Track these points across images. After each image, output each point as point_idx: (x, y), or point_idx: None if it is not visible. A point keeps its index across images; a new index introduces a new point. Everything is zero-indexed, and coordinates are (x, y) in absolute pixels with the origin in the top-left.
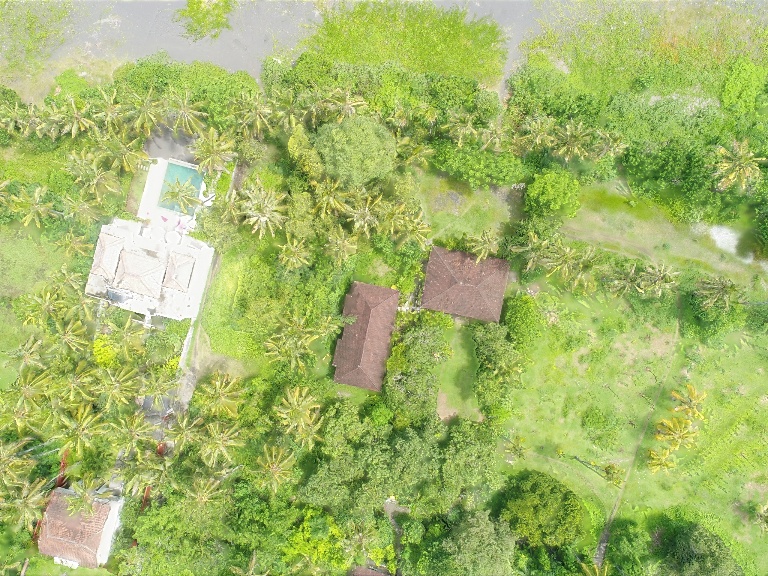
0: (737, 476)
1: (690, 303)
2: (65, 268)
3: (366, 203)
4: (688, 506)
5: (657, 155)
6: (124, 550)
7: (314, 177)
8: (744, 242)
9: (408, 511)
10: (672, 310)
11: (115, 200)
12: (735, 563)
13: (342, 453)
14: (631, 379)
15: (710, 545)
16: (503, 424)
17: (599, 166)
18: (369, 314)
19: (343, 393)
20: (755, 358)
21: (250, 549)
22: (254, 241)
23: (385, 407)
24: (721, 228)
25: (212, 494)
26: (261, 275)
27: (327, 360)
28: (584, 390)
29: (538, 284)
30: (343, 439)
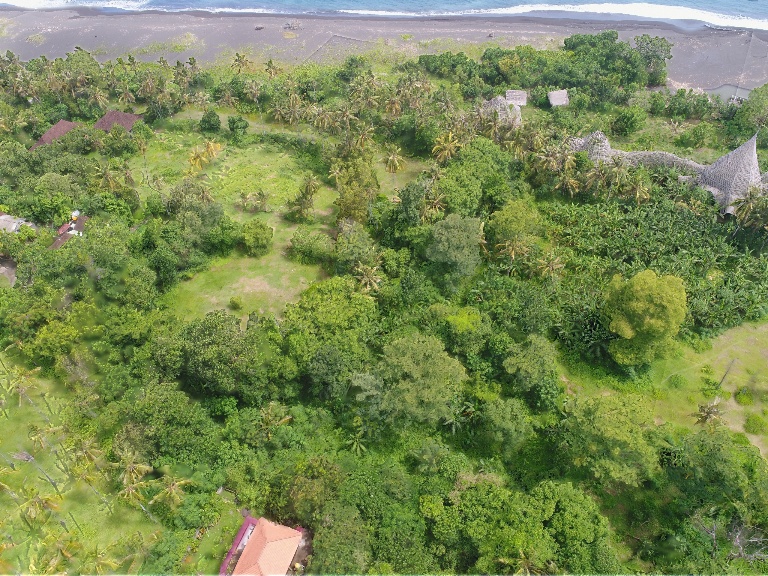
0: None
1: None
2: None
3: None
4: None
5: None
6: None
7: None
8: None
9: None
10: (224, 135)
11: None
12: None
13: None
14: None
15: None
16: None
17: None
18: (59, 121)
19: None
20: (264, 152)
21: None
22: None
23: None
24: None
25: None
26: None
27: (29, 142)
28: None
29: (160, 131)
30: (13, 155)
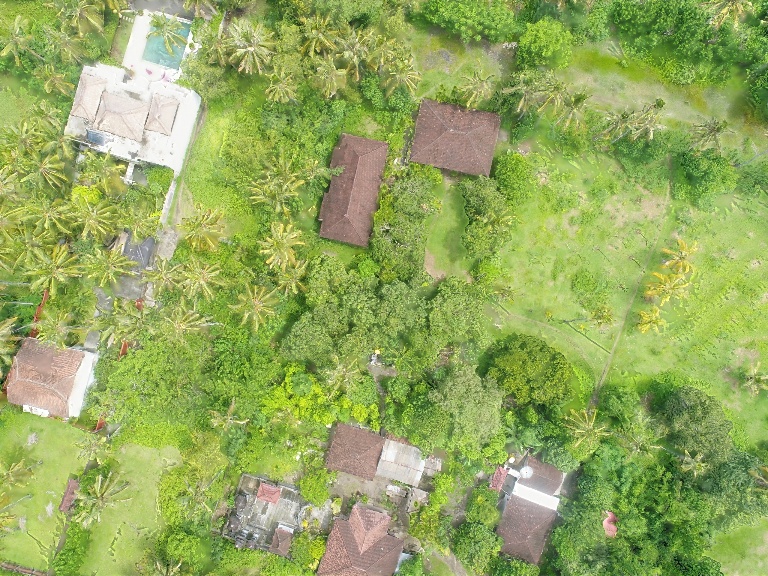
0: (727, 342)
1: (681, 163)
2: (44, 105)
3: (356, 38)
4: (678, 372)
5: (649, 7)
6: (97, 393)
7: (303, 13)
8: (735, 105)
9: (393, 375)
10: (663, 171)
11: (98, 42)
12: (725, 419)
13: (326, 302)
14: (621, 242)
15: (700, 396)
16: (492, 286)
17: (591, 24)
18: (357, 162)
19: (329, 253)
20: (746, 221)
21: (229, 400)
22: (241, 96)
23: (372, 260)
24: (712, 91)
25: (191, 324)
26: (247, 128)
27: (313, 212)
28: (574, 252)
29: (529, 144)
30: (328, 288)
